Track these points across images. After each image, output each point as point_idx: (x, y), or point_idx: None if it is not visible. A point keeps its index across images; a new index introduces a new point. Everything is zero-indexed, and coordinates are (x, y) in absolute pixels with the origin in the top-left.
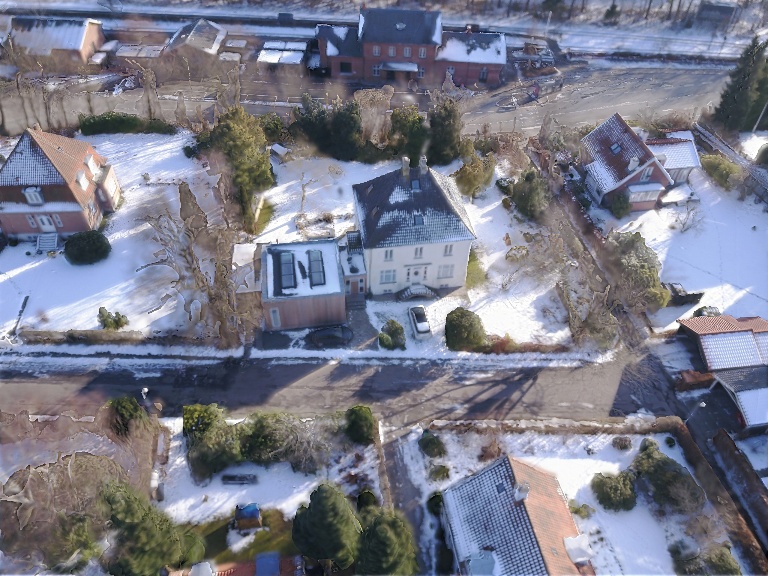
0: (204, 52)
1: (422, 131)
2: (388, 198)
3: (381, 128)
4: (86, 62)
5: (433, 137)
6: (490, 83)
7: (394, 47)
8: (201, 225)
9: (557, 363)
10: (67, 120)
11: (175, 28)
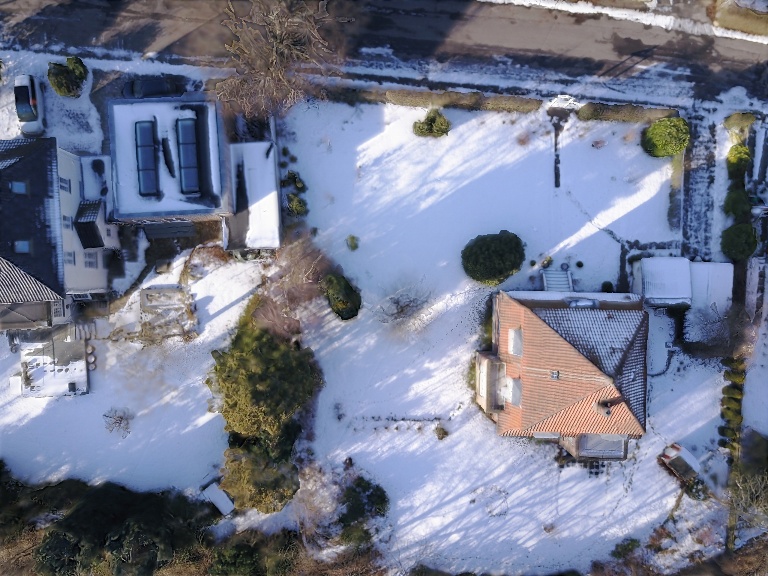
0: None
1: None
2: None
3: None
4: None
5: None
6: None
7: None
8: None
9: None
10: None
11: None
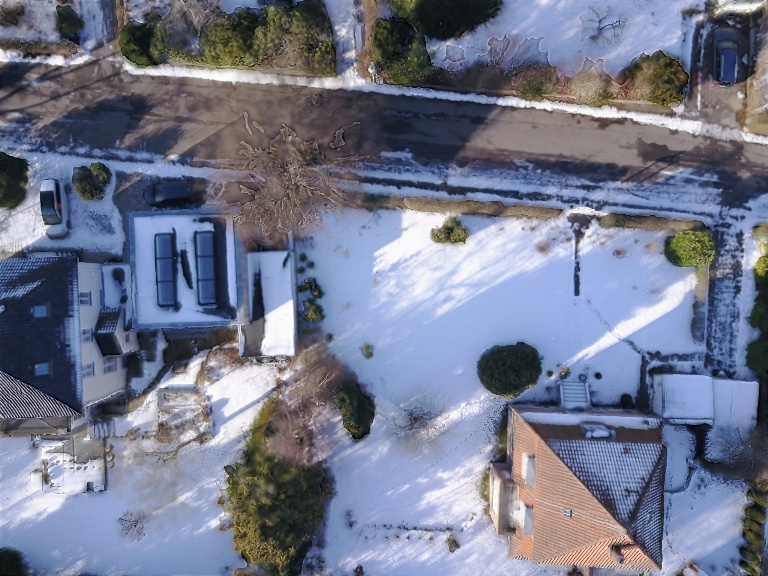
0: None
1: None
2: (4, 312)
3: None
4: None
5: None
6: None
7: None
8: None
9: None
10: None
11: None
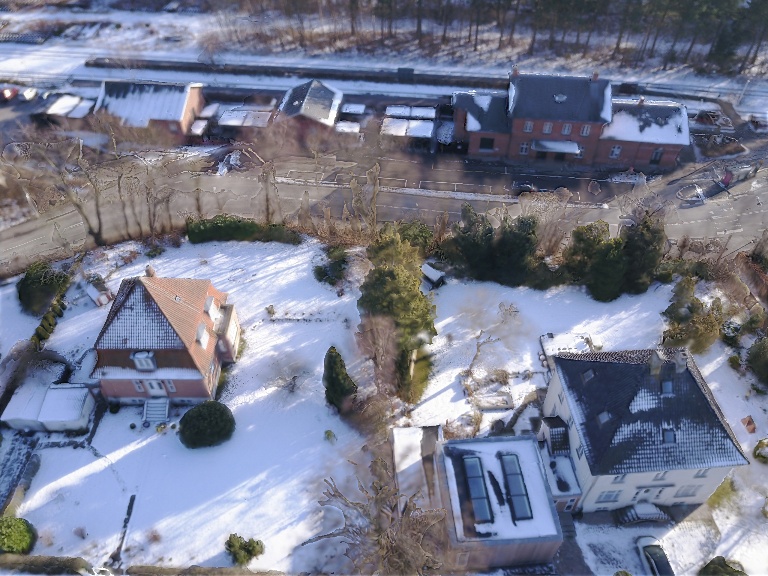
0: (320, 123)
1: (617, 258)
2: (628, 405)
3: (549, 238)
4: (186, 133)
5: (629, 263)
6: (664, 165)
7: (551, 123)
8: (350, 398)
9: None
10: (172, 223)
11: (279, 84)
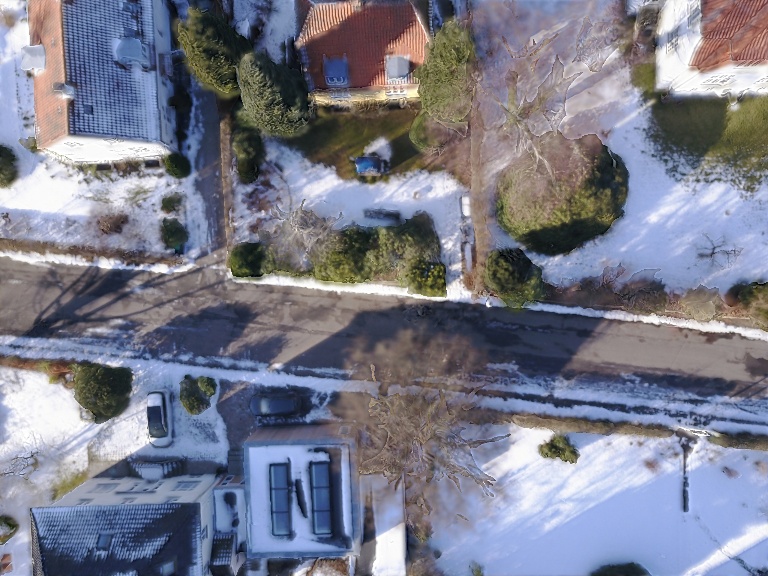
0: None
1: None
2: None
3: None
4: None
5: None
6: None
7: None
8: None
9: (5, 341)
10: None
11: None
